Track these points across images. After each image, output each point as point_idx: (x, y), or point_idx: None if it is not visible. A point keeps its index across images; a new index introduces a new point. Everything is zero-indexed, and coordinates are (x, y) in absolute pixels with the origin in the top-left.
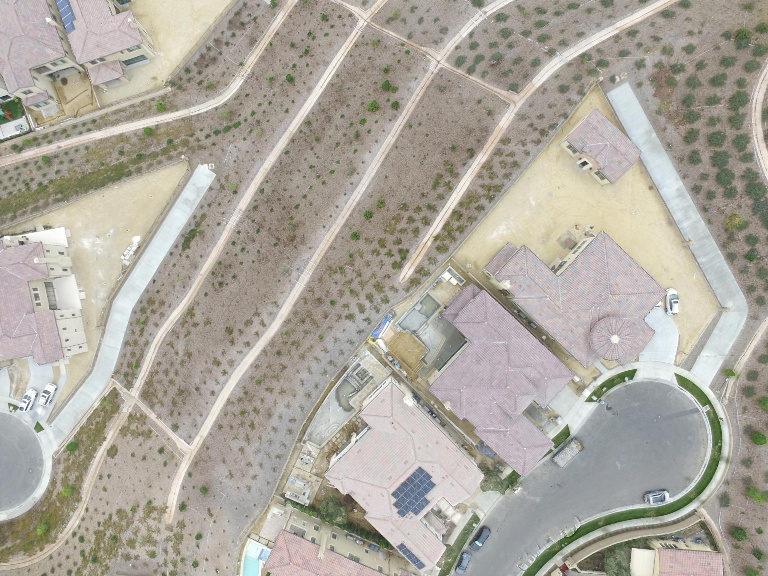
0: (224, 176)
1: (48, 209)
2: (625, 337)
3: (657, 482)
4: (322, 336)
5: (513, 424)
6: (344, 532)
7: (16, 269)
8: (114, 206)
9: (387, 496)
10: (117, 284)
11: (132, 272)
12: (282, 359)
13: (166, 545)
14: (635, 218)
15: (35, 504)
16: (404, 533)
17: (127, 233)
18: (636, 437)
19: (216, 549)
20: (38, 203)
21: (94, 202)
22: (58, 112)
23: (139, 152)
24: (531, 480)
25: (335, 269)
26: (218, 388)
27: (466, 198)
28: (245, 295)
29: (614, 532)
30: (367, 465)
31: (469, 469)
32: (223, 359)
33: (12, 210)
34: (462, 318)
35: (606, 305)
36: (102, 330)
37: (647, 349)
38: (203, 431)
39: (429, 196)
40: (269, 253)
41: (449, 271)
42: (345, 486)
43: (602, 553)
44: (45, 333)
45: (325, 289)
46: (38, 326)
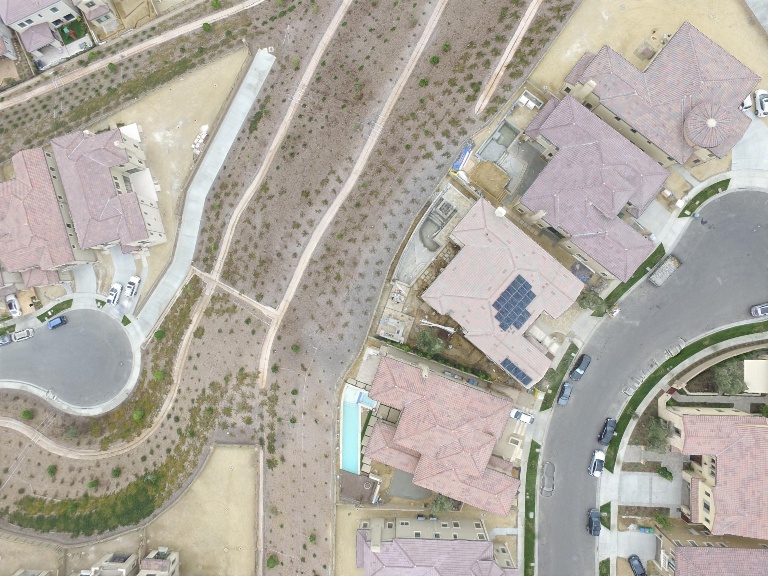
0: (284, 57)
1: (119, 107)
2: (723, 121)
3: (763, 295)
4: (401, 179)
5: (611, 226)
6: (441, 370)
7: (98, 155)
8: (181, 98)
9: (488, 308)
10: (190, 173)
11: (203, 161)
12: (362, 210)
13: (261, 410)
14: (714, 22)
15: (128, 396)
16: (508, 347)
17: (195, 123)
18: (736, 250)
19: (313, 400)
20: (109, 104)
21: (162, 96)
22: (118, 26)
23: (200, 47)
24: (628, 304)
25: (406, 117)
26: (300, 250)
27: (535, 24)
28: (318, 158)
29: (721, 351)
30: (464, 280)
31: (569, 278)
32: (302, 220)
33: (86, 114)
34: (548, 124)
35: (698, 93)
36: (179, 220)
37: (739, 157)
38: (288, 295)
39: (496, 29)
40: (338, 116)
41: (525, 95)
42: (443, 305)
43: (712, 371)
44: (129, 214)
45: (398, 137)
46: (123, 207)
